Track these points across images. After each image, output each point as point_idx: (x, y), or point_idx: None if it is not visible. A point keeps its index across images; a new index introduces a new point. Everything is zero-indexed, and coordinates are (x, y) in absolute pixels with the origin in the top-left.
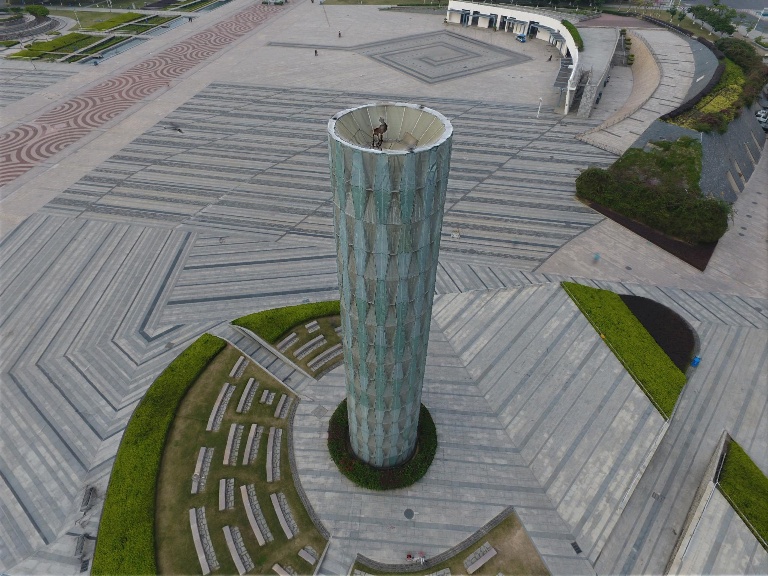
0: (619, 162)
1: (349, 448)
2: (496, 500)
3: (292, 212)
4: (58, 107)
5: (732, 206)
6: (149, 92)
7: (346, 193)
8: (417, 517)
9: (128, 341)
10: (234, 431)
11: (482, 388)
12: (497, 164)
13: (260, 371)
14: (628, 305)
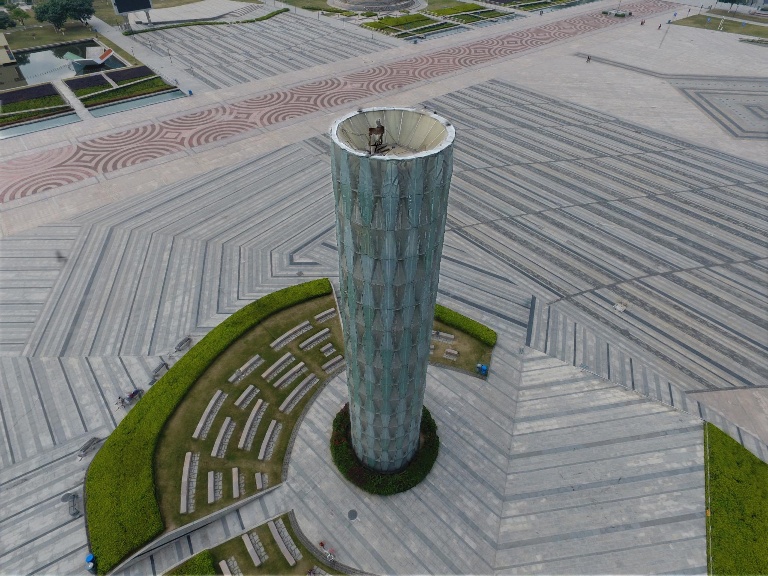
0: None
1: None
2: (434, 569)
3: (470, 214)
4: (365, 70)
5: None
6: (437, 74)
7: None
8: (356, 522)
9: (279, 257)
10: (286, 358)
11: (512, 466)
12: (750, 255)
13: (338, 327)
14: None
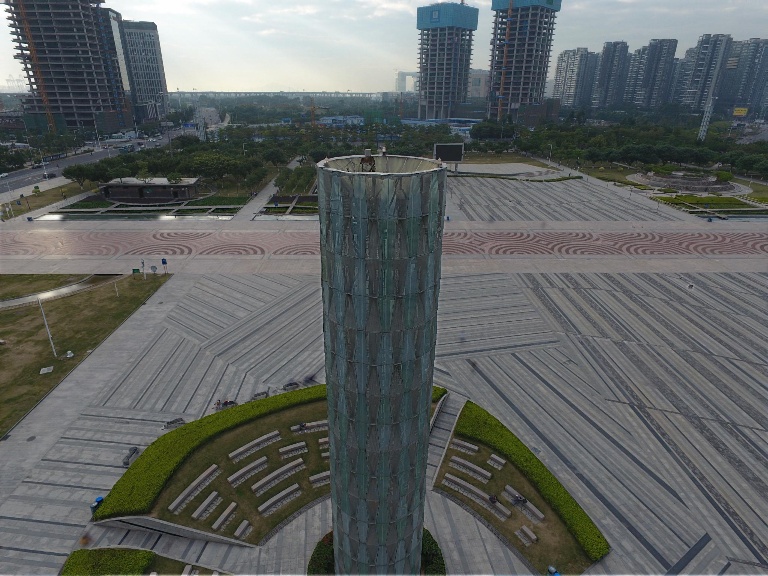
0: None
1: None
2: None
3: (669, 398)
4: (629, 233)
5: None
6: (719, 252)
7: None
8: None
9: None
10: None
11: None
12: None
13: None
14: None
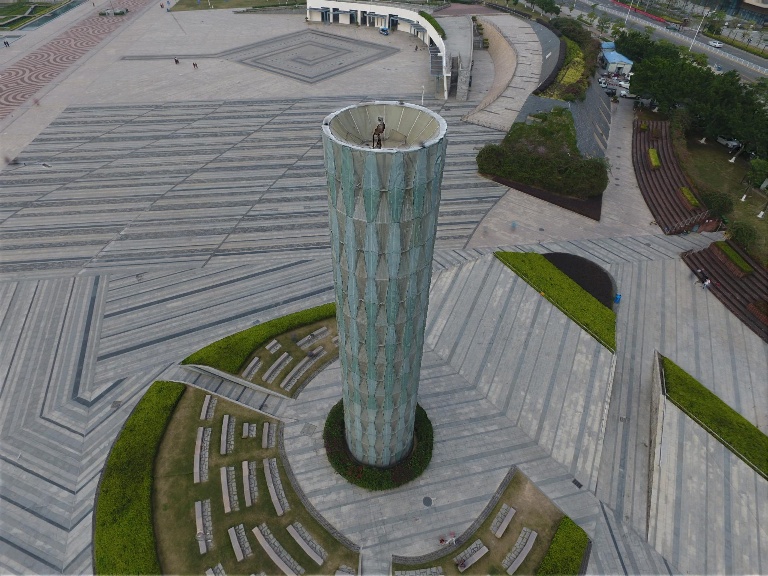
0: (508, 137)
1: (350, 457)
2: (499, 464)
3: (210, 233)
4: None
5: (609, 161)
6: None
7: (355, 198)
8: (436, 502)
9: (62, 412)
10: (226, 475)
11: (454, 365)
12: None
13: (232, 405)
14: (552, 262)
